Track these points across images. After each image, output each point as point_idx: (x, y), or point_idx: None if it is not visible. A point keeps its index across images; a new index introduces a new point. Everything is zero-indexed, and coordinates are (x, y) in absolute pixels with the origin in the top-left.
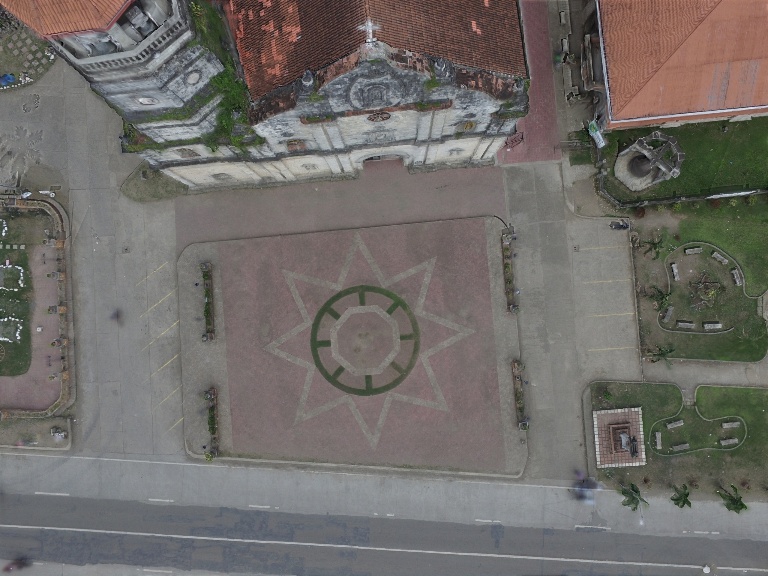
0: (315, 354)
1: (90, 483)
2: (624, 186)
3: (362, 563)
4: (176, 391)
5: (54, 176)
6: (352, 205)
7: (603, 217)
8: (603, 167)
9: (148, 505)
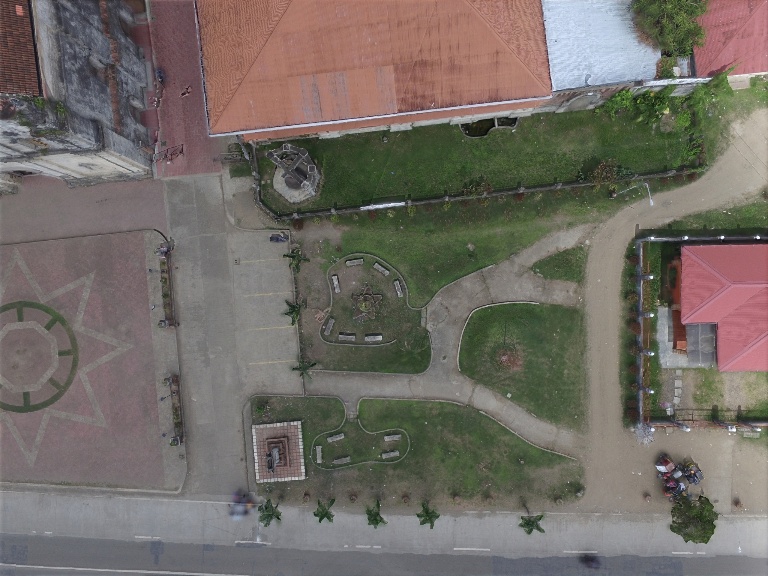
0: None
1: None
2: (283, 198)
3: None
4: None
5: None
6: (11, 220)
7: (263, 229)
8: (263, 179)
9: None
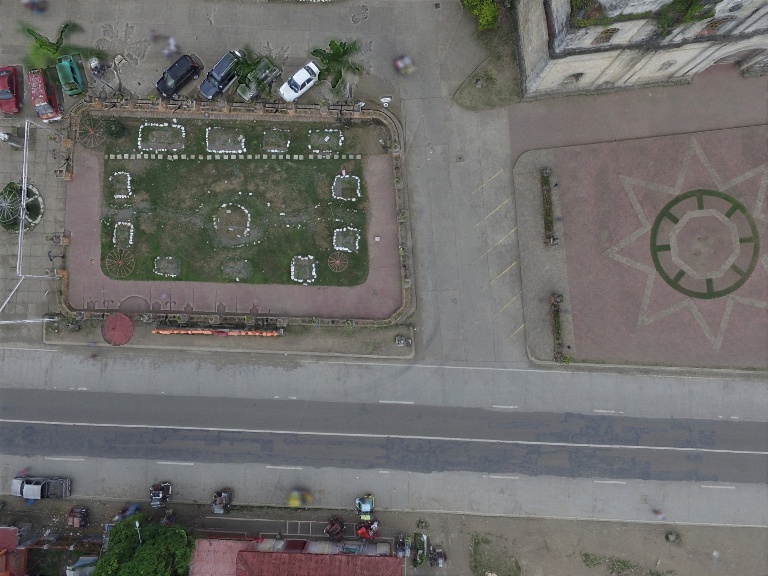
0: (655, 258)
1: (433, 391)
2: None
3: (708, 466)
4: (516, 298)
5: (385, 86)
6: (686, 110)
7: None
8: None
9: (492, 412)
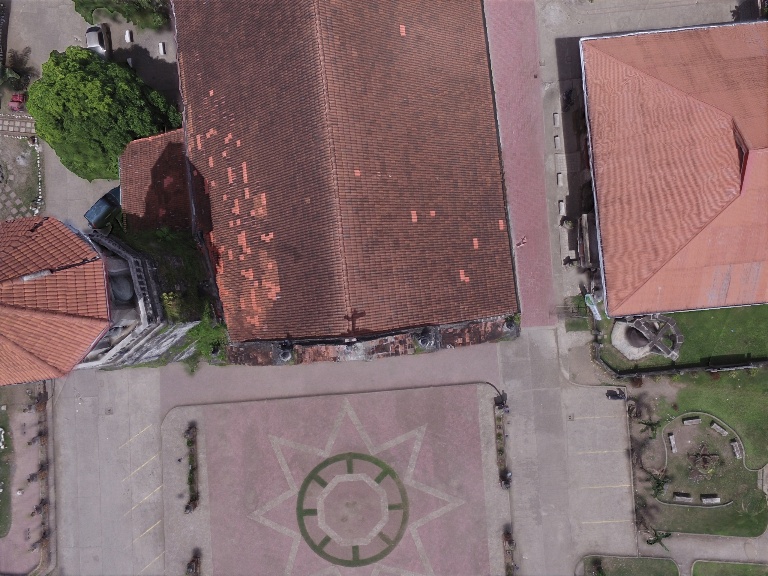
0: (301, 523)
1: None
2: (621, 354)
3: None
4: (158, 558)
5: None
6: (341, 369)
7: (599, 386)
8: None
9: None
